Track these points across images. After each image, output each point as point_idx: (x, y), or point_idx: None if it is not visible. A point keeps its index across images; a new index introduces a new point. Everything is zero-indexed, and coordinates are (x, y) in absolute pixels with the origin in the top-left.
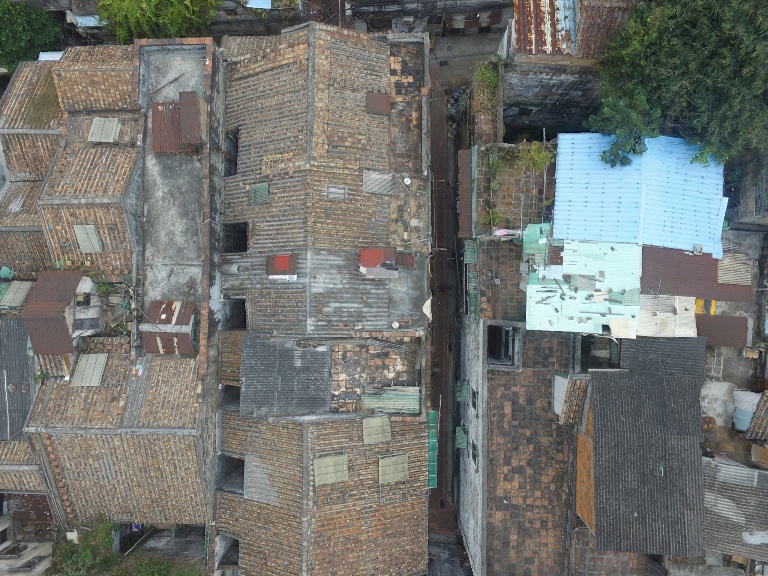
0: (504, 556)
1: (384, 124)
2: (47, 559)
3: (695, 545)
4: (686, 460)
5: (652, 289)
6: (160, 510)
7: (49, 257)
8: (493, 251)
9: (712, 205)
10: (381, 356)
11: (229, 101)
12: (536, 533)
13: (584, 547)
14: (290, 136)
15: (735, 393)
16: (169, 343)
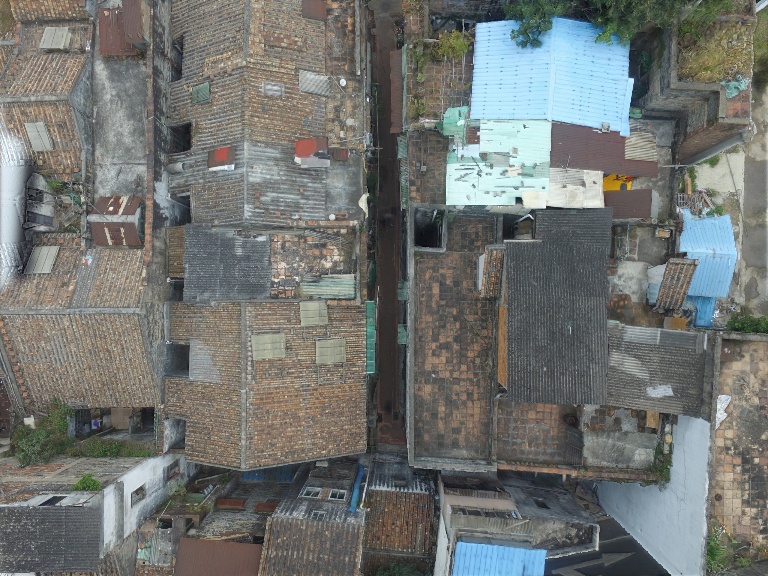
0: (433, 427)
1: (320, 29)
2: (7, 446)
3: (599, 395)
4: (592, 319)
5: (562, 163)
6: (111, 393)
7: (5, 161)
8: (421, 143)
9: (619, 86)
10: (319, 246)
11: (174, 11)
12: (463, 404)
13: (508, 417)
14: (229, 37)
15: (649, 271)
16: (117, 234)
